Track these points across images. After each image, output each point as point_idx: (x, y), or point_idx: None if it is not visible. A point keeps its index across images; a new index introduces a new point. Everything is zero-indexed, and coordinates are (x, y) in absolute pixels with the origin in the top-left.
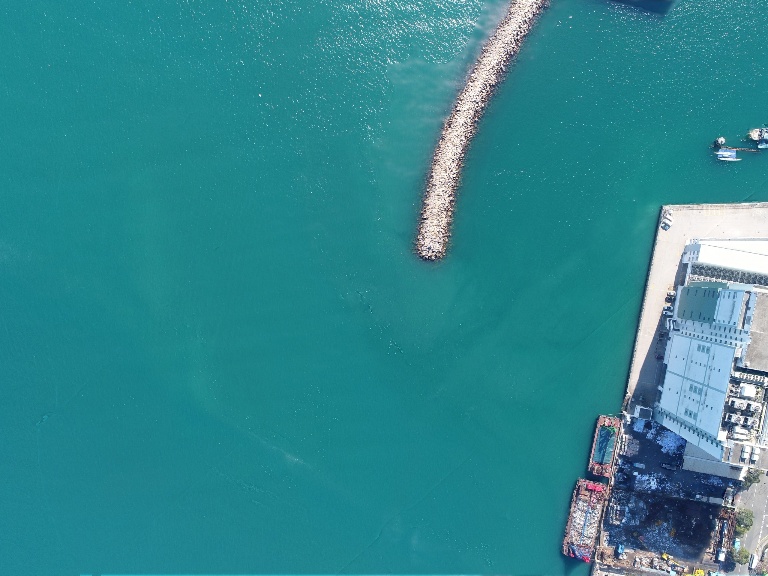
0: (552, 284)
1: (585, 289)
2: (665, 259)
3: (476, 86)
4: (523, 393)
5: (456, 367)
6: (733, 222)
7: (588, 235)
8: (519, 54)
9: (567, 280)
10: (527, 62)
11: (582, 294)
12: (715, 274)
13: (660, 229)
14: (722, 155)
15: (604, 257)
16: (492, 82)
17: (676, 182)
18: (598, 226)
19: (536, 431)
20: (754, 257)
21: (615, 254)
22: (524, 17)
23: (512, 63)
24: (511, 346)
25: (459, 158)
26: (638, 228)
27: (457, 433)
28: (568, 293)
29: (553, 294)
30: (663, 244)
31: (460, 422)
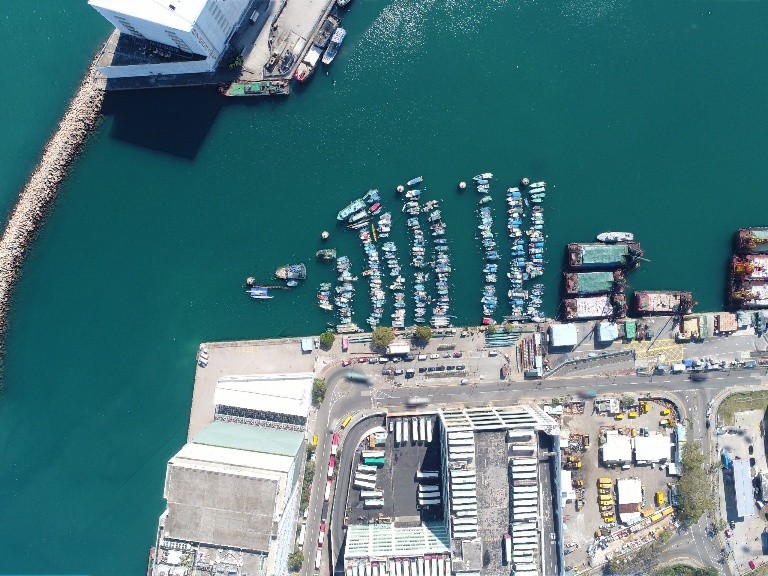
0: (101, 422)
1: (135, 425)
2: (204, 395)
3: (11, 233)
4: (81, 528)
5: (16, 505)
6: (266, 358)
7: (134, 373)
8: (57, 199)
9: (116, 417)
10: (67, 206)
11: (132, 430)
12: (239, 412)
13: (198, 366)
14: (254, 293)
15: (150, 394)
16: (29, 228)
17: (216, 319)
18: (142, 364)
19: (94, 564)
20: (266, 398)
21: (160, 391)
22: (54, 165)
23: (50, 208)
24: (67, 482)
25: (3, 302)
26: (181, 365)
27: (9, 573)
28: (118, 430)
29: (105, 431)
30: (202, 381)
31: (20, 559)
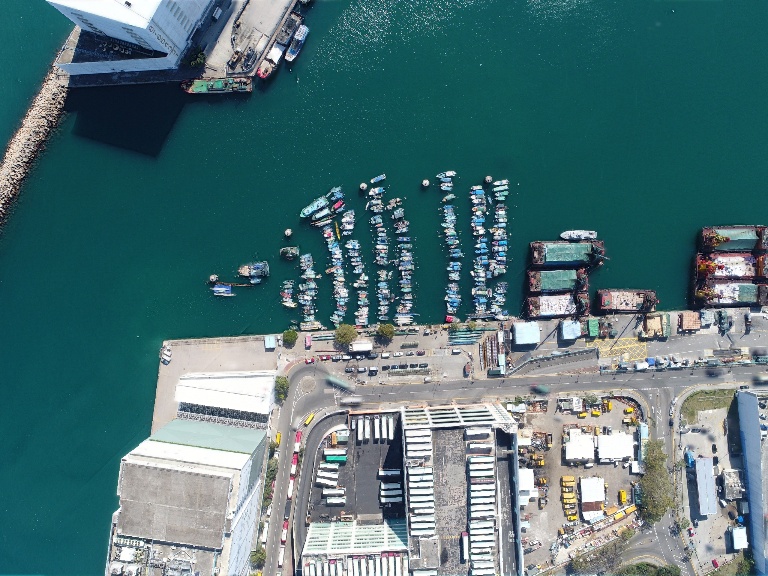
0: (64, 419)
1: (98, 422)
2: (167, 392)
3: None
4: (44, 525)
5: None
6: (229, 355)
7: (98, 370)
8: (20, 196)
9: (79, 414)
10: (30, 203)
11: (95, 427)
12: (201, 410)
13: (161, 364)
14: (218, 291)
15: (113, 391)
16: None
17: (179, 317)
18: (105, 362)
19: (58, 561)
20: (227, 396)
21: (123, 388)
22: (16, 162)
23: (13, 205)
24: (31, 479)
25: None
26: (144, 362)
27: None
28: (81, 427)
29: (68, 428)
30: (165, 378)
31: None
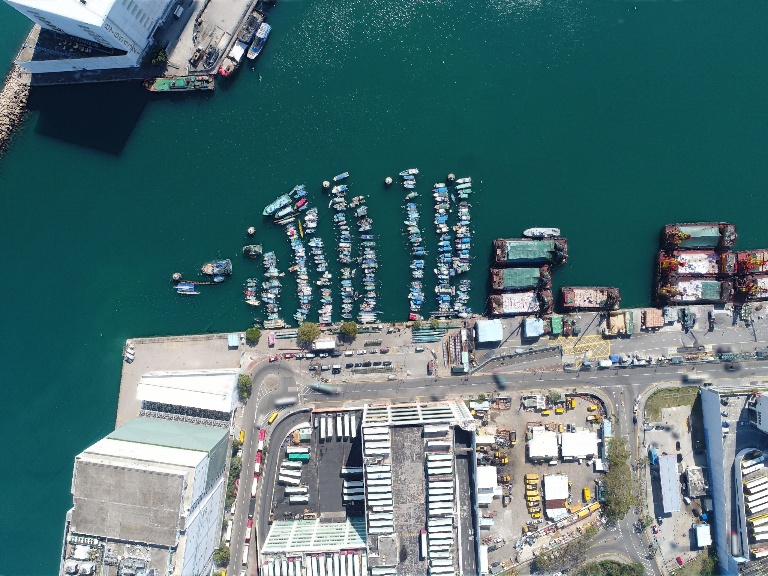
0: (28, 417)
1: (62, 421)
2: (131, 391)
3: None
4: (9, 523)
5: None
6: (193, 353)
7: (61, 369)
8: None
9: (43, 413)
10: None
11: (60, 426)
12: (164, 408)
13: (124, 362)
14: (181, 289)
15: (77, 390)
16: None
17: (143, 315)
18: (69, 360)
19: (23, 560)
20: (189, 394)
21: (87, 386)
22: None
23: None
24: None
25: None
26: (108, 360)
27: None
28: (45, 425)
29: (32, 426)
30: (128, 376)
31: None
